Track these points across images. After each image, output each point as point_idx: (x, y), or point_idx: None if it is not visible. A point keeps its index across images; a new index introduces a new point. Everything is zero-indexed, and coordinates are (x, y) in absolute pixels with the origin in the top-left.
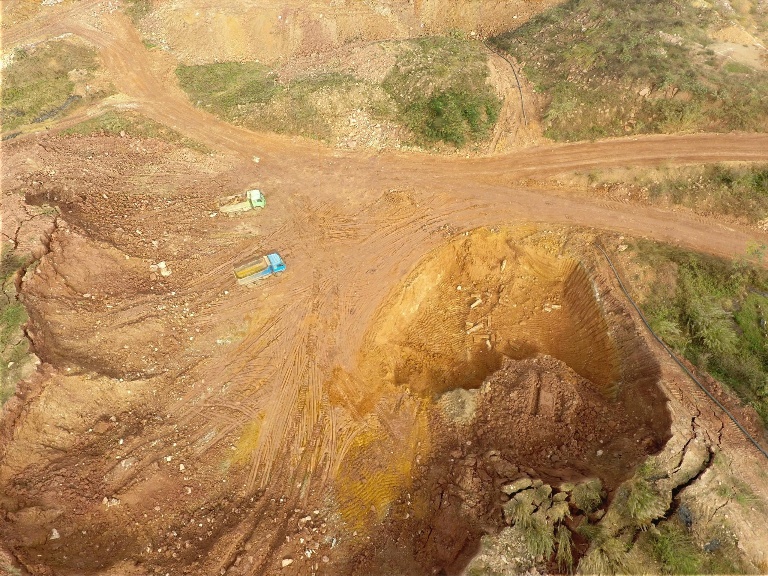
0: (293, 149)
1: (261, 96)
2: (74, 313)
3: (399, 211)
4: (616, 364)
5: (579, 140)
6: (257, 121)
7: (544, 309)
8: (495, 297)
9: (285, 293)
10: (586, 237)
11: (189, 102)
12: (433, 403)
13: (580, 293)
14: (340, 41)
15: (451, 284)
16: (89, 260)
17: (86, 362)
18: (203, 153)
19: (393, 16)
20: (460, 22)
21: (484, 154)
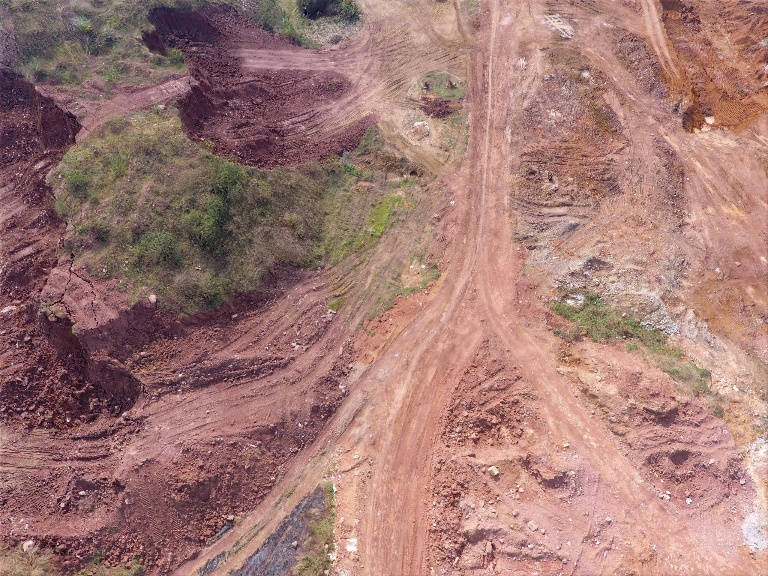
0: None
1: None
2: None
3: None
4: None
5: None
6: None
7: None
8: None
9: None
10: None
11: None
12: None
13: None
14: None
15: None
16: None
17: None
18: None
19: None
20: None
21: None
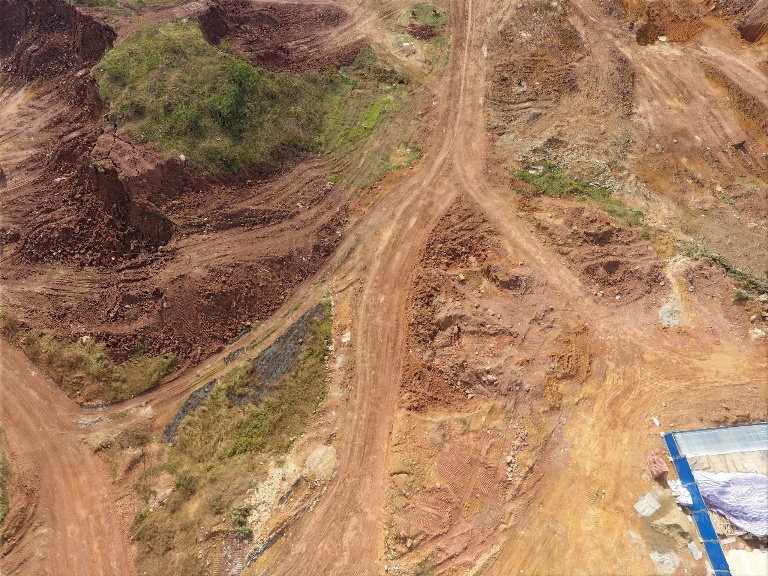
0: None
1: None
2: None
3: None
4: None
5: None
6: None
7: None
8: None
9: None
10: None
11: (4, 428)
12: None
13: None
14: None
15: None
16: None
17: None
18: (4, 316)
19: None
20: None
21: None
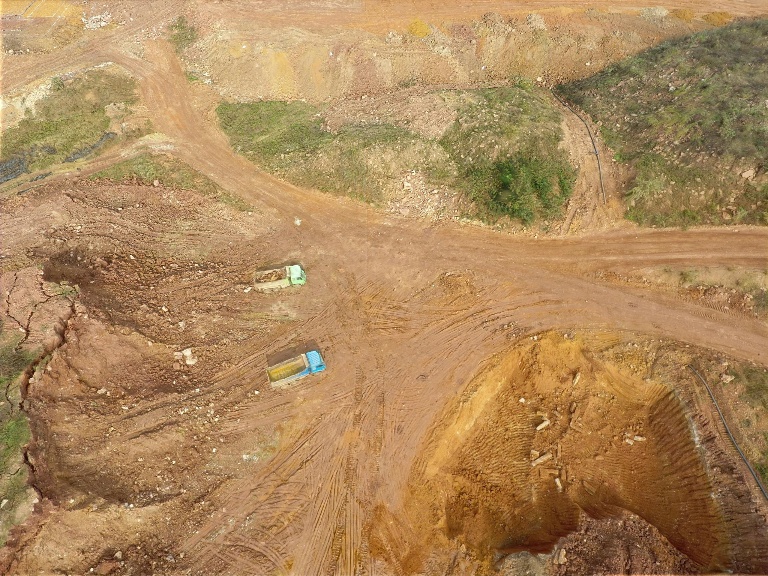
0: (339, 211)
1: (306, 143)
2: (85, 418)
3: (456, 300)
4: (723, 540)
5: (668, 226)
6: (301, 175)
7: (625, 440)
8: (565, 418)
9: (323, 398)
10: (680, 357)
11: (229, 146)
12: (494, 569)
13: (672, 428)
14: (394, 83)
15: (513, 394)
16: (107, 348)
17: (94, 480)
18: (240, 210)
19: (453, 57)
20: (526, 66)
21: (555, 235)
